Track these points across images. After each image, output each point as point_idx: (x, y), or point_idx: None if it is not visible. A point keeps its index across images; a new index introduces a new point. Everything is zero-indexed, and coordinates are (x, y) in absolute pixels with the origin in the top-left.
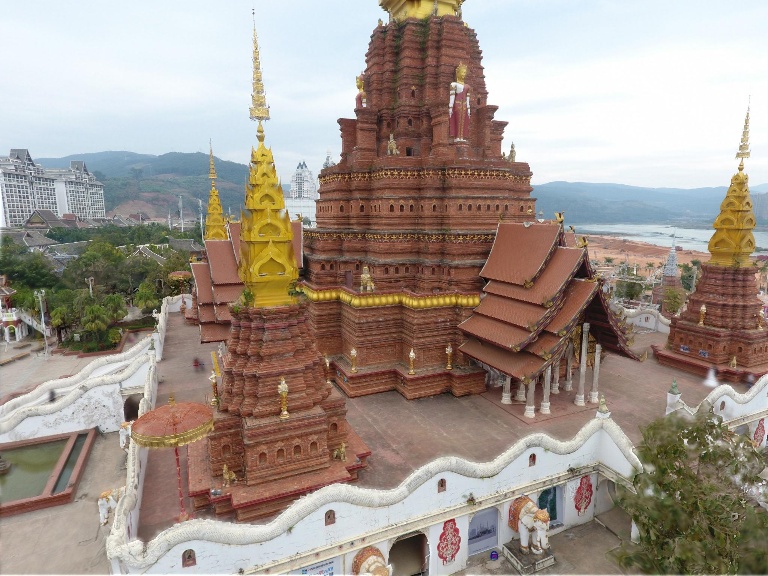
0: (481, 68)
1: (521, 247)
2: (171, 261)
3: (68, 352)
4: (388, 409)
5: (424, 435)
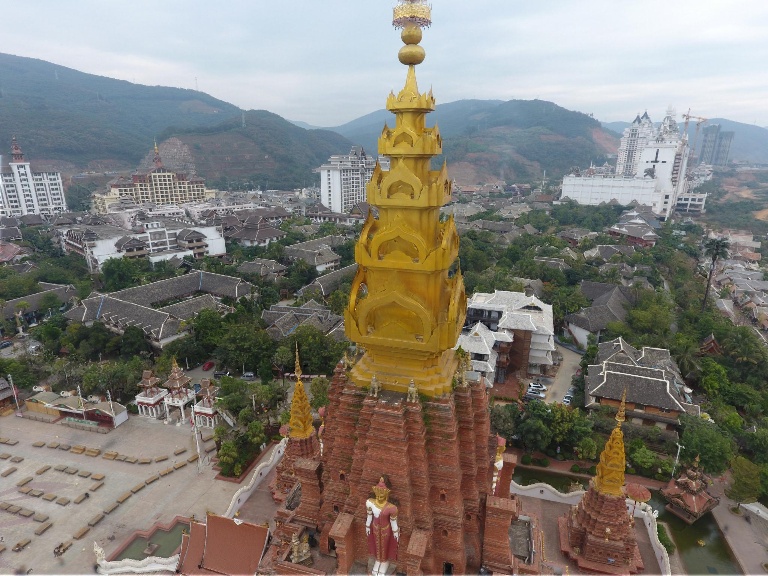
0: (451, 455)
1: None
2: (316, 384)
3: (215, 467)
4: None
5: None
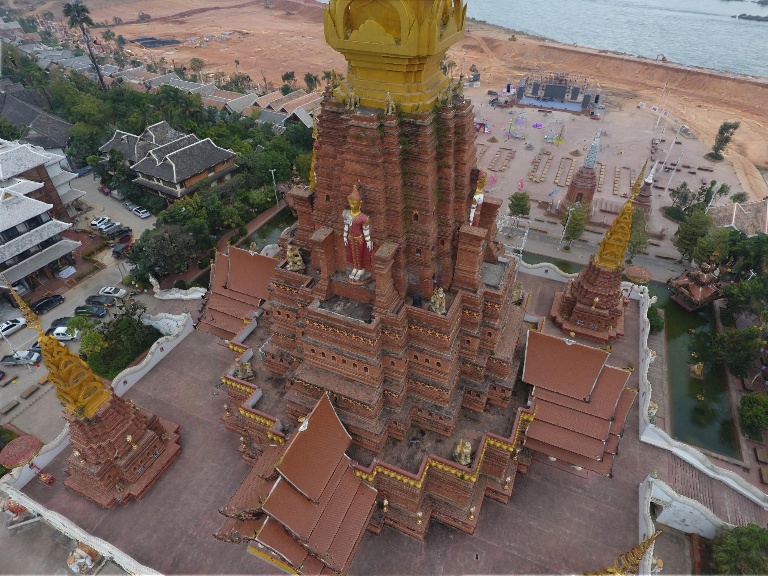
0: None
1: (565, 361)
2: None
3: None
4: (509, 528)
5: (561, 543)
